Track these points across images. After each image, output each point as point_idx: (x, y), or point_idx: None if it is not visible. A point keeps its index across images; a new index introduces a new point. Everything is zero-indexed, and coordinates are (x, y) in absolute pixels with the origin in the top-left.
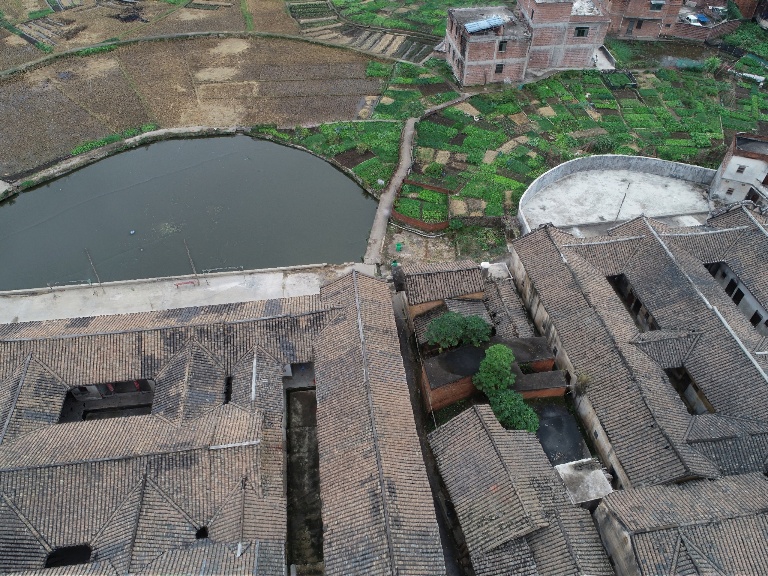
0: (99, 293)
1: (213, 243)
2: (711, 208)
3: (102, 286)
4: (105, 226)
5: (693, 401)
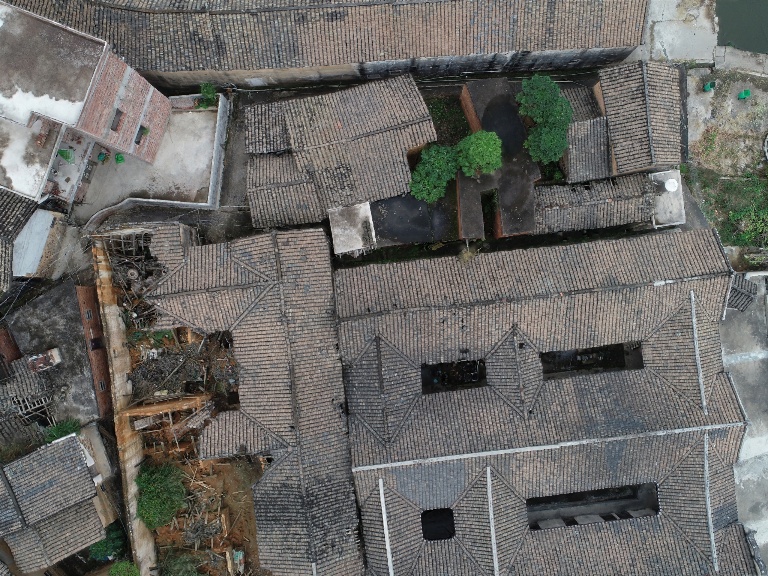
0: None
1: None
2: None
3: None
4: None
5: None
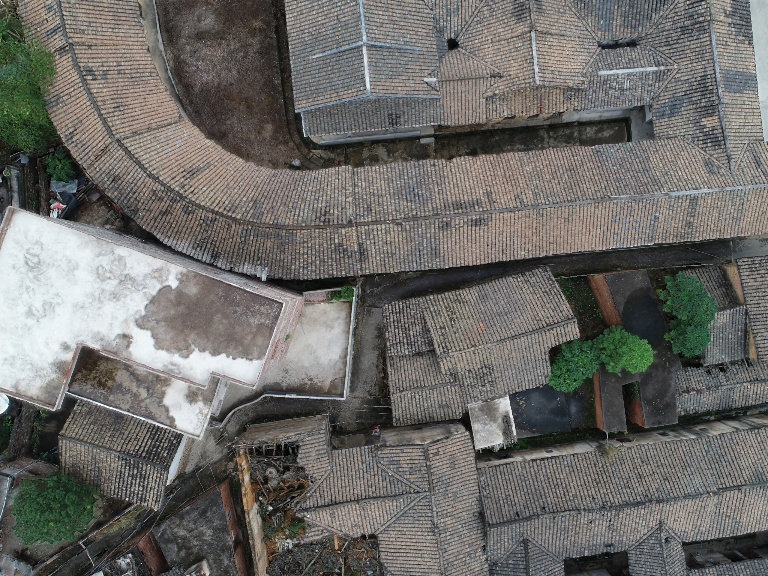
0: None
1: None
2: None
3: None
4: None
5: (593, 574)
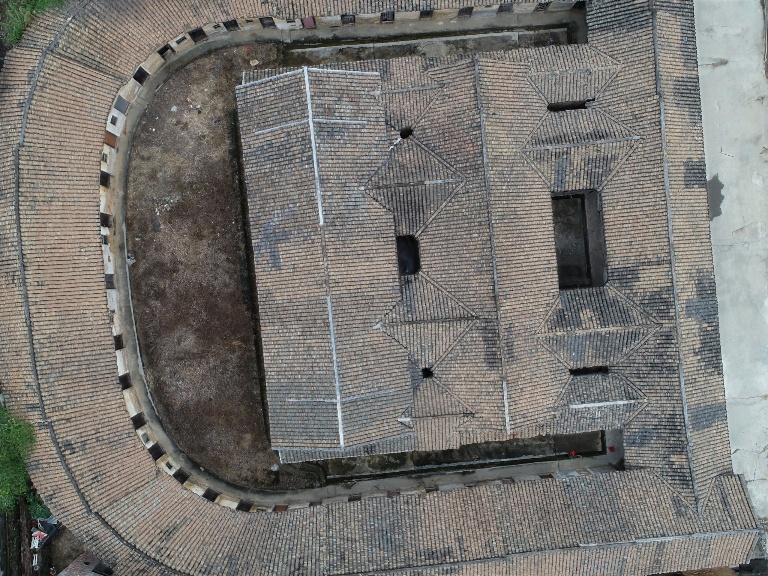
0: (766, 154)
1: None
2: None
3: None
4: None
5: None
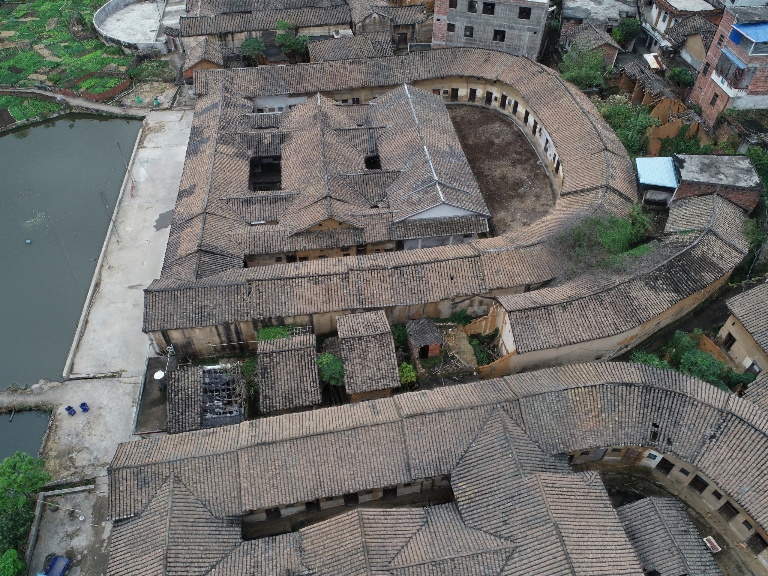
0: None
1: (77, 190)
2: (163, 1)
3: (109, 240)
4: (3, 264)
5: None
